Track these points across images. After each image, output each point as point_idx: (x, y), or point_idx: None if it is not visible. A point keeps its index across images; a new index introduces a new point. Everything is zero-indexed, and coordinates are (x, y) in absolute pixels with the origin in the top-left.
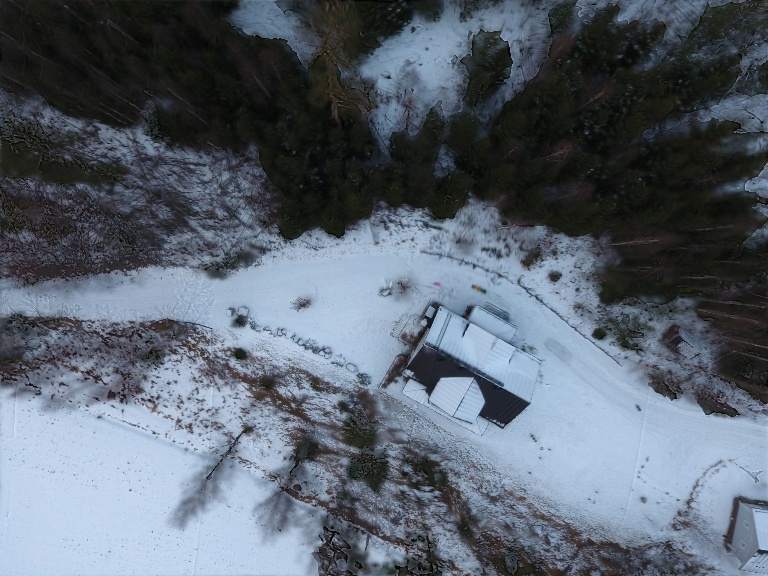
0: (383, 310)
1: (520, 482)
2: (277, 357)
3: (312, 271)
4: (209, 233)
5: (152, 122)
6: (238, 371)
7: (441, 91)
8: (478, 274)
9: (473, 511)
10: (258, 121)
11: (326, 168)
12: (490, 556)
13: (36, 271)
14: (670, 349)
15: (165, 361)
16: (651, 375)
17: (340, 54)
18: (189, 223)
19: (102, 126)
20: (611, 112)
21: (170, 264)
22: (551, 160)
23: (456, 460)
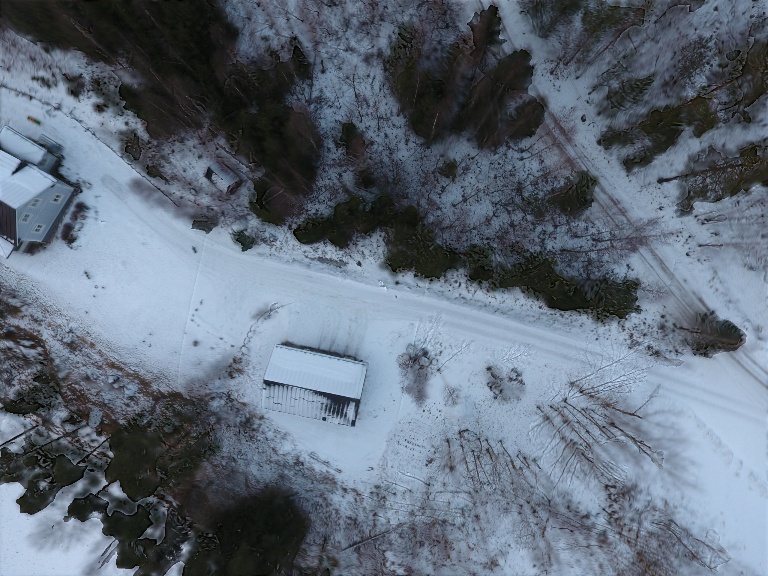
0: None
1: (83, 324)
2: None
3: None
4: None
5: None
6: None
7: None
8: (34, 106)
9: (56, 361)
10: None
11: None
12: (78, 412)
13: None
14: None
15: None
16: (207, 217)
17: None
18: None
19: None
20: None
21: None
22: None
23: (33, 305)
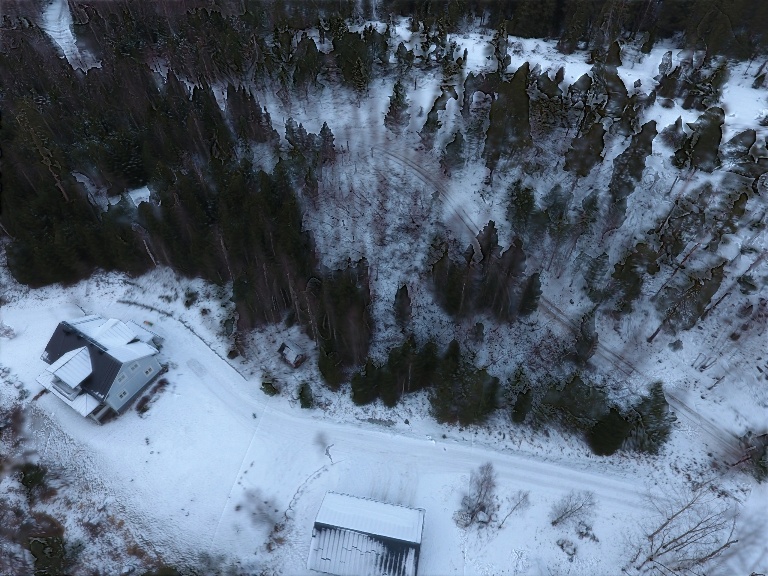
0: None
1: (122, 497)
2: None
3: (32, 316)
4: None
5: None
6: None
7: None
8: (152, 314)
9: (67, 554)
10: (21, 199)
11: None
12: None
13: None
14: (287, 365)
15: None
16: None
17: (104, 195)
18: None
19: None
20: (218, 193)
21: None
22: None
23: (74, 484)
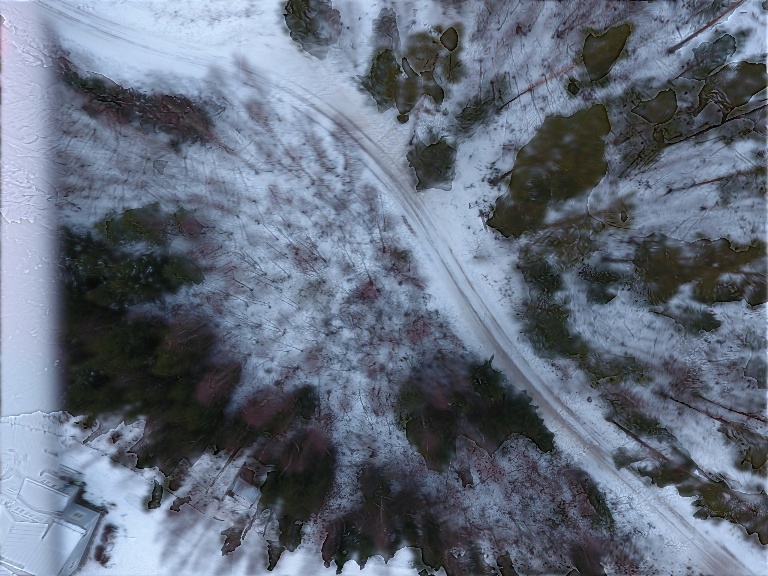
0: None
1: None
2: None
3: None
4: None
5: None
6: None
7: None
8: (49, 438)
9: None
10: None
11: None
12: None
13: None
14: None
15: None
16: (233, 520)
17: None
18: None
19: None
20: (35, 320)
21: None
22: None
23: None
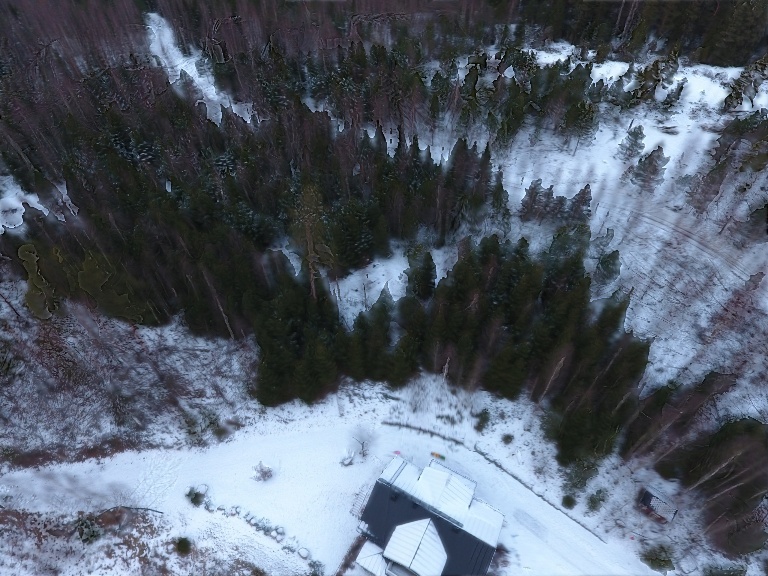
0: (343, 481)
1: None
2: (224, 546)
3: (279, 445)
4: (194, 411)
5: (179, 322)
6: (174, 575)
7: (394, 298)
8: (436, 442)
9: None
10: (258, 298)
11: (303, 337)
12: None
13: (15, 459)
14: (650, 518)
15: (94, 568)
16: (643, 554)
17: None
18: (179, 402)
19: (140, 326)
20: (507, 286)
21: (146, 446)
22: (468, 310)
23: None
